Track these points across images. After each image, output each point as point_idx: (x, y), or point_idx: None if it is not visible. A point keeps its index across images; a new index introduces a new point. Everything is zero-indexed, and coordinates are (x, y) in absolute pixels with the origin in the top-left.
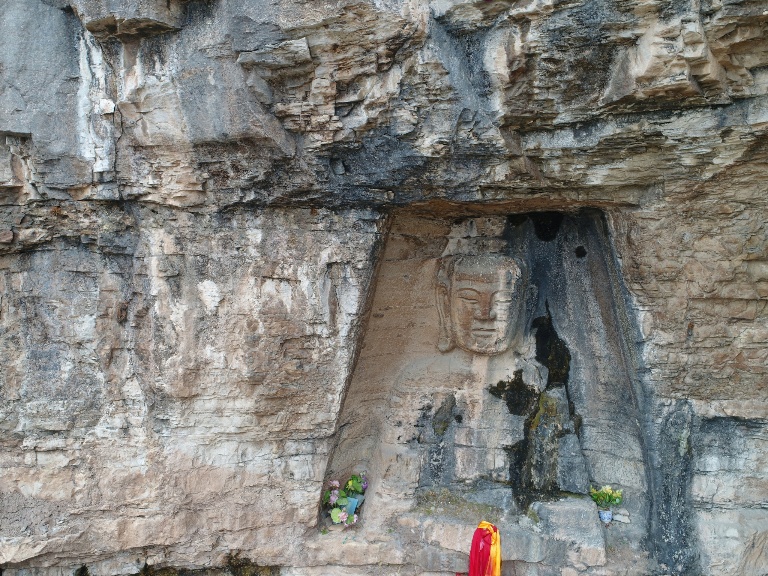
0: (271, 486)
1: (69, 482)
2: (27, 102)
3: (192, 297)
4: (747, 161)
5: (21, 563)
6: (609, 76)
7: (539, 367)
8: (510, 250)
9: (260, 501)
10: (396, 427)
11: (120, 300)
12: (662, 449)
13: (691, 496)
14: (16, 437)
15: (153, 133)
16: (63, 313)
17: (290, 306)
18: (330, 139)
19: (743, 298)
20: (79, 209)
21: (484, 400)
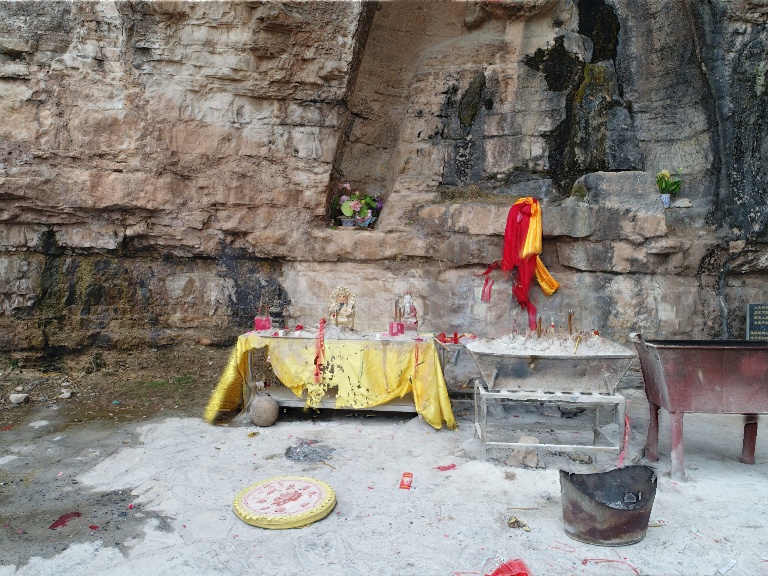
0: (272, 162)
1: (33, 122)
2: None
3: None
4: None
5: None
6: None
7: (583, 37)
8: None
9: (259, 174)
10: (416, 119)
11: None
12: (734, 92)
13: (767, 152)
14: None
15: None
16: None
17: None
18: None
19: None
20: None
21: (519, 75)
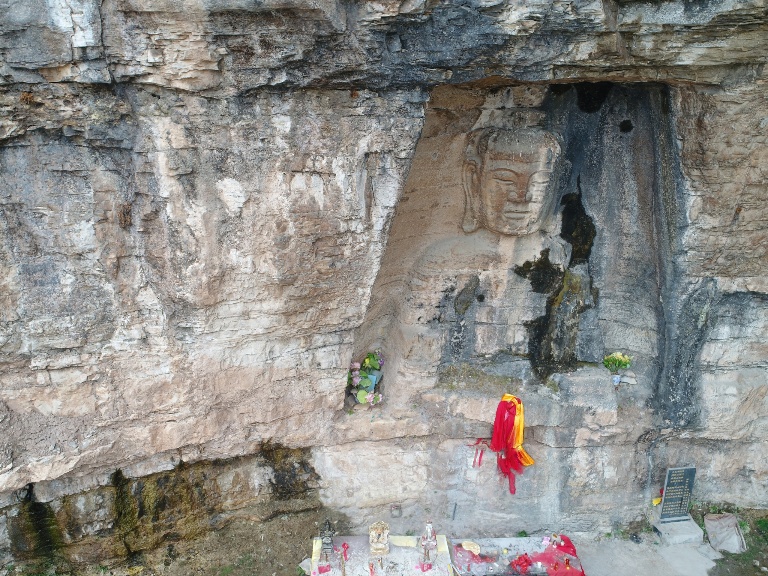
0: (299, 378)
1: (90, 396)
2: None
3: (210, 197)
4: None
5: None
6: None
7: (564, 245)
8: (548, 123)
9: (290, 393)
10: (417, 309)
11: (119, 201)
12: (681, 322)
13: (699, 361)
14: (22, 358)
15: None
16: (54, 221)
17: (322, 202)
18: (395, 11)
19: None
20: (57, 94)
21: (509, 280)
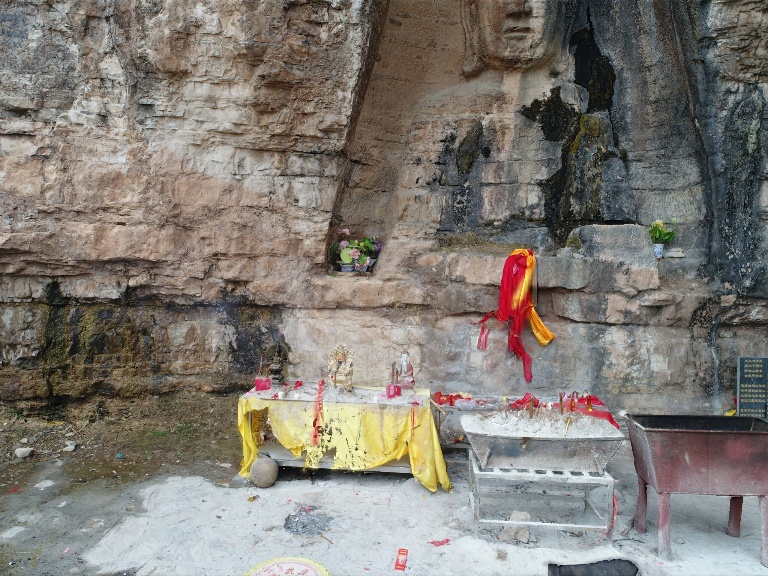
0: (272, 211)
1: (38, 177)
2: None
3: None
4: None
5: None
6: None
7: (579, 88)
8: None
9: (259, 224)
10: (414, 166)
11: None
12: (726, 149)
13: (759, 207)
14: None
15: None
16: None
17: None
18: None
19: None
20: None
21: (516, 125)
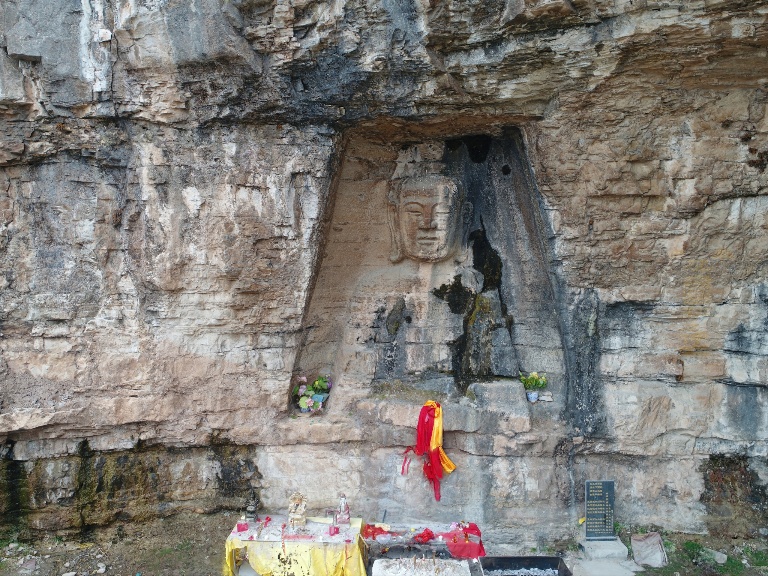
0: (247, 375)
1: (72, 366)
2: (37, 30)
3: (177, 202)
4: (620, 73)
5: (31, 435)
6: (506, 0)
7: (476, 273)
8: (449, 171)
9: (238, 387)
10: (355, 329)
11: (115, 208)
12: (575, 332)
13: (600, 372)
14: (26, 325)
15: (144, 57)
16: (66, 217)
17: (261, 211)
18: (290, 57)
19: (629, 194)
20: (80, 125)
21: (429, 302)
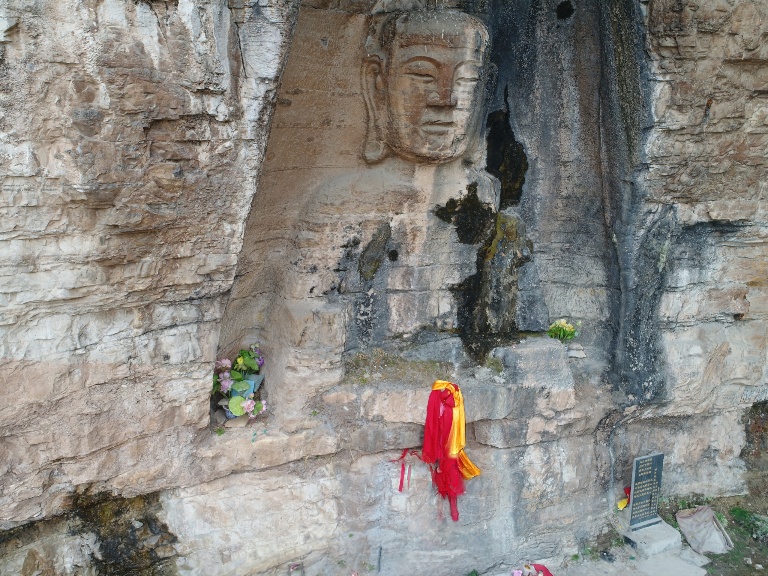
0: (134, 379)
1: None
2: None
3: None
4: None
5: None
6: None
7: (493, 180)
8: (470, 6)
9: (119, 404)
10: (308, 275)
11: None
12: (639, 266)
13: (658, 317)
14: None
15: None
16: None
17: (157, 55)
18: None
19: None
20: None
21: (429, 227)
